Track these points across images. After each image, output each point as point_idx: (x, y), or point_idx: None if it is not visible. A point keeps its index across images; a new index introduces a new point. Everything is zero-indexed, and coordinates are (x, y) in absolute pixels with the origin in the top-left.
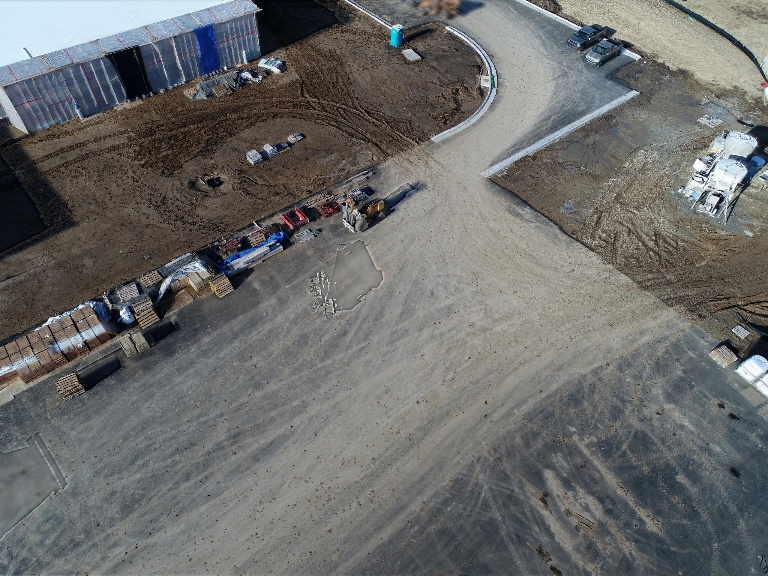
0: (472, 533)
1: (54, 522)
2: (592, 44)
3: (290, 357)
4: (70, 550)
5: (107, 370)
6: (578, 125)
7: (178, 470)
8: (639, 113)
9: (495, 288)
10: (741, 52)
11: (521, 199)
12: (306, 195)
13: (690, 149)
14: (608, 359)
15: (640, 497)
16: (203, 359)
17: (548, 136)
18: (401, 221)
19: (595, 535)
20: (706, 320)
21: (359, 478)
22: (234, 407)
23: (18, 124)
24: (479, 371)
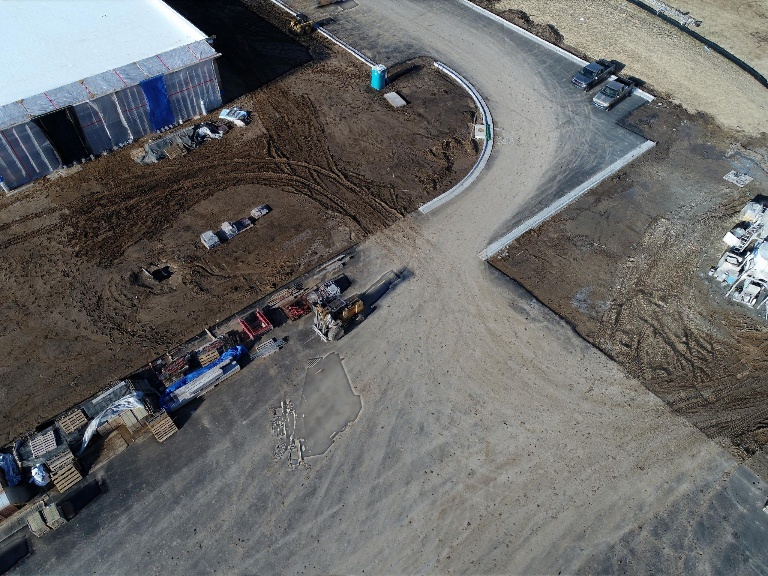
0: None
1: None
2: (599, 82)
3: (244, 530)
4: None
5: (10, 558)
6: (588, 188)
7: None
8: (657, 170)
9: (498, 418)
10: (765, 89)
11: (526, 289)
12: (270, 290)
13: (718, 216)
14: (640, 520)
15: None
16: (134, 536)
17: (554, 203)
18: (384, 324)
19: None
20: (755, 456)
21: None
22: None
23: None
24: (481, 544)
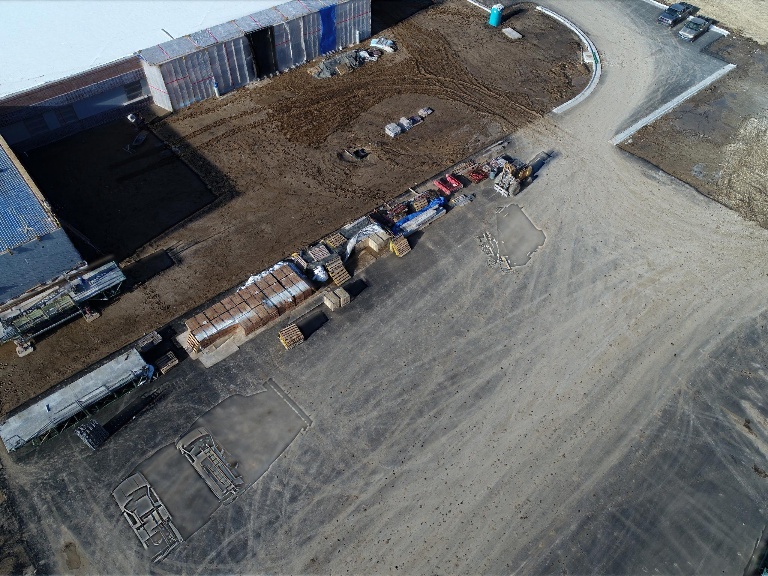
0: (691, 455)
1: (312, 454)
2: (680, 21)
3: (481, 308)
4: (335, 477)
5: (317, 322)
6: (688, 96)
7: (410, 407)
8: (740, 84)
9: (652, 244)
10: None
11: (653, 164)
12: (451, 164)
13: None
14: None
15: None
16: (402, 311)
17: (662, 107)
18: (547, 186)
19: None
20: None
21: (577, 411)
22: (444, 352)
23: (163, 102)
24: (658, 317)
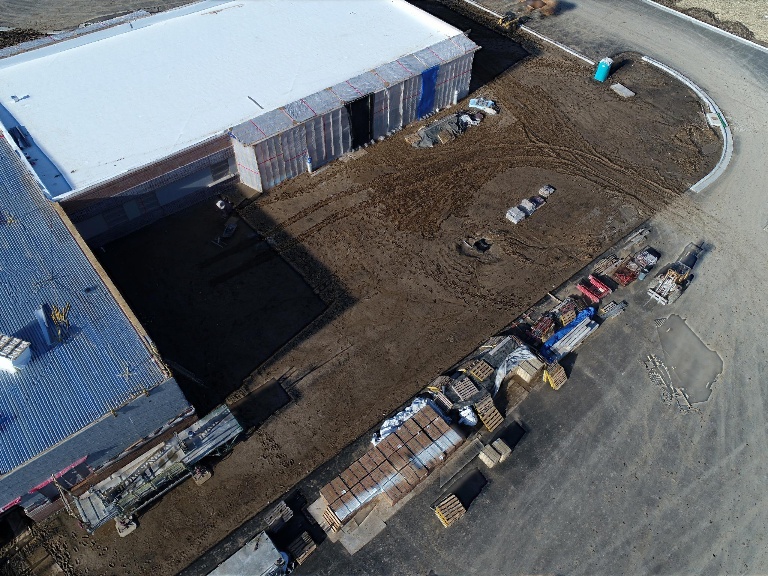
0: None
1: None
2: None
3: (669, 464)
4: None
5: (474, 486)
6: None
7: None
8: None
9: None
10: None
11: None
12: (589, 259)
13: None
14: None
15: None
16: (573, 469)
17: None
18: (707, 289)
19: None
20: None
21: None
22: (637, 531)
23: (251, 182)
24: None
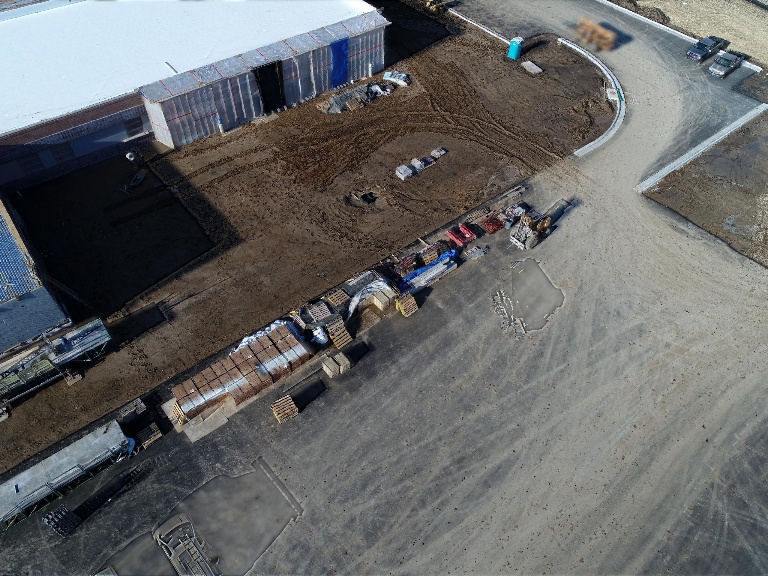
0: (726, 564)
1: (301, 550)
2: (710, 56)
3: (493, 379)
4: None
5: (313, 392)
6: (718, 139)
7: (412, 496)
8: None
9: (680, 307)
10: None
11: (681, 215)
12: (464, 211)
13: None
14: None
15: None
16: (406, 380)
17: (691, 150)
18: (566, 238)
19: None
20: None
21: (597, 505)
22: (451, 430)
23: (164, 139)
24: (688, 394)
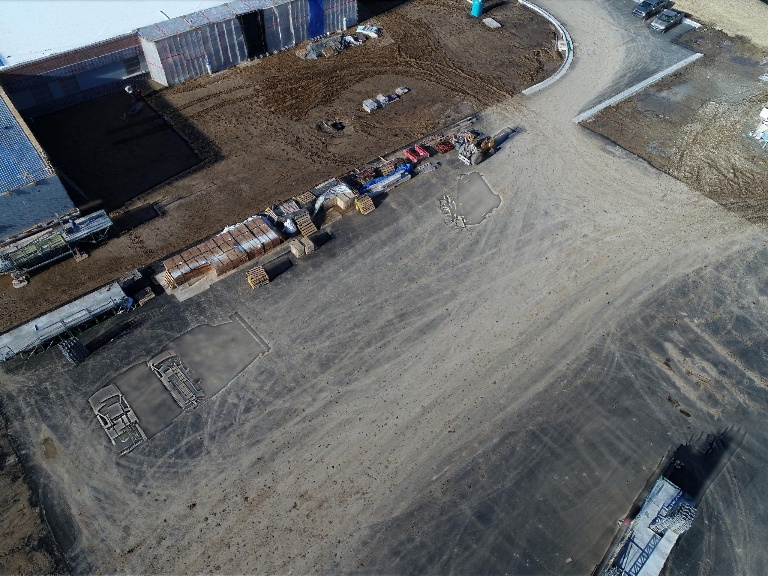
0: (612, 386)
1: (267, 374)
2: (655, 14)
3: (434, 259)
4: (286, 394)
5: (282, 267)
6: (652, 81)
7: (360, 339)
8: (705, 72)
9: (600, 209)
10: None
11: (611, 140)
12: (421, 136)
13: (755, 101)
14: (706, 263)
15: (747, 363)
16: (361, 260)
17: (626, 90)
18: (508, 157)
19: (714, 389)
20: None
21: (511, 346)
22: (395, 295)
23: (159, 77)
24: (597, 270)
